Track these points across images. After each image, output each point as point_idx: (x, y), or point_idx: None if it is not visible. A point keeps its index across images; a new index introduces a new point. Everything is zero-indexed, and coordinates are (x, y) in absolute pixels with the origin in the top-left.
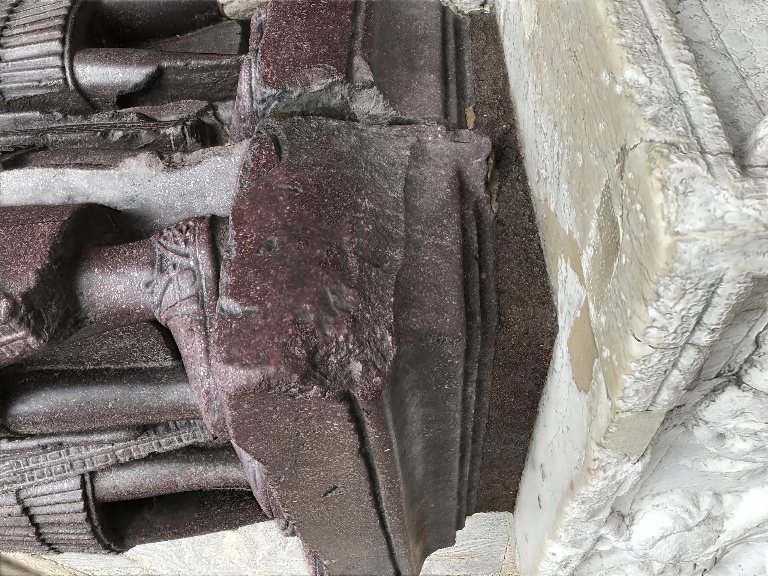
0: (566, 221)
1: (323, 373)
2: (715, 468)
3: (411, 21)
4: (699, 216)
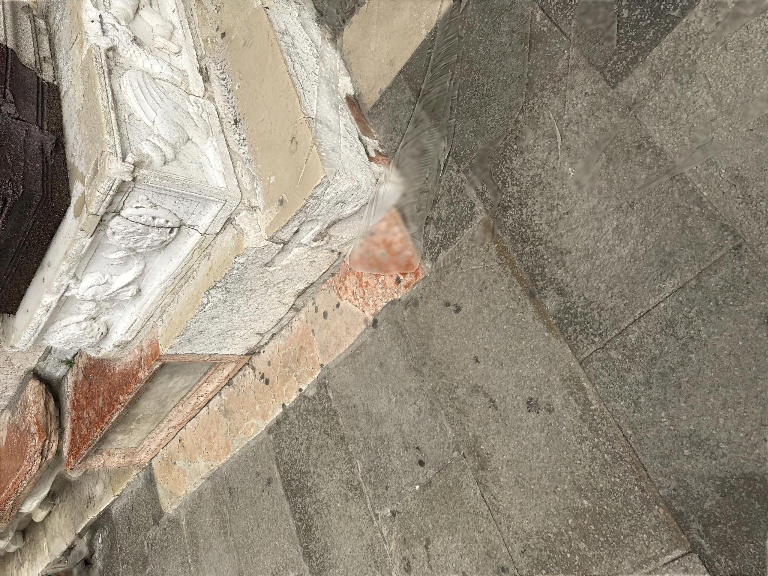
0: (81, 169)
1: (0, 190)
2: (111, 257)
3: (25, 79)
4: (114, 166)
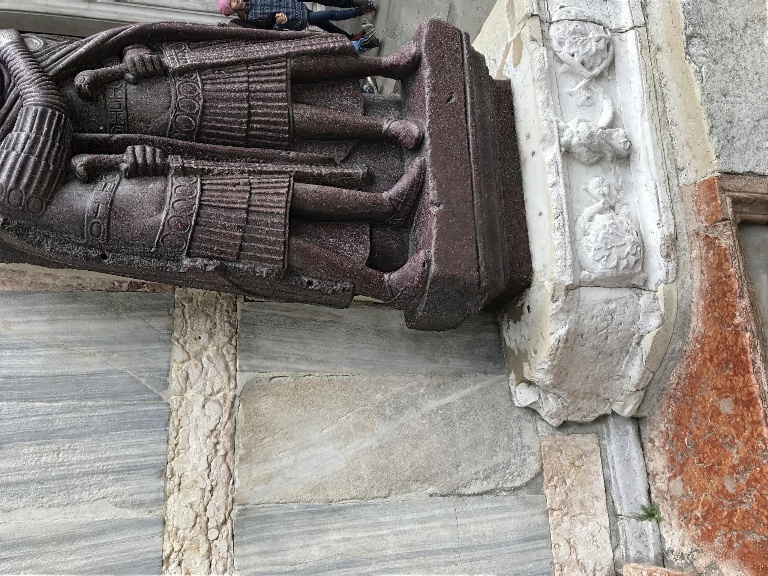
0: None
1: None
2: None
3: None
4: None
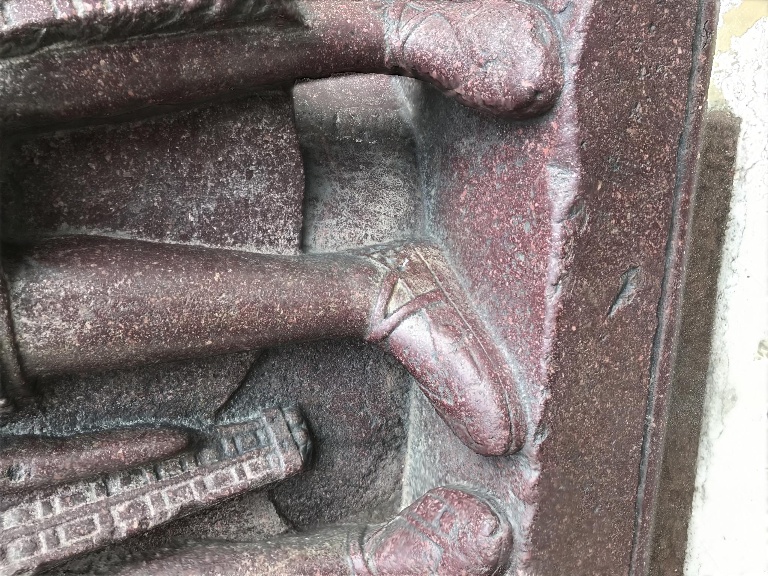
0: None
1: None
2: None
3: None
4: None
